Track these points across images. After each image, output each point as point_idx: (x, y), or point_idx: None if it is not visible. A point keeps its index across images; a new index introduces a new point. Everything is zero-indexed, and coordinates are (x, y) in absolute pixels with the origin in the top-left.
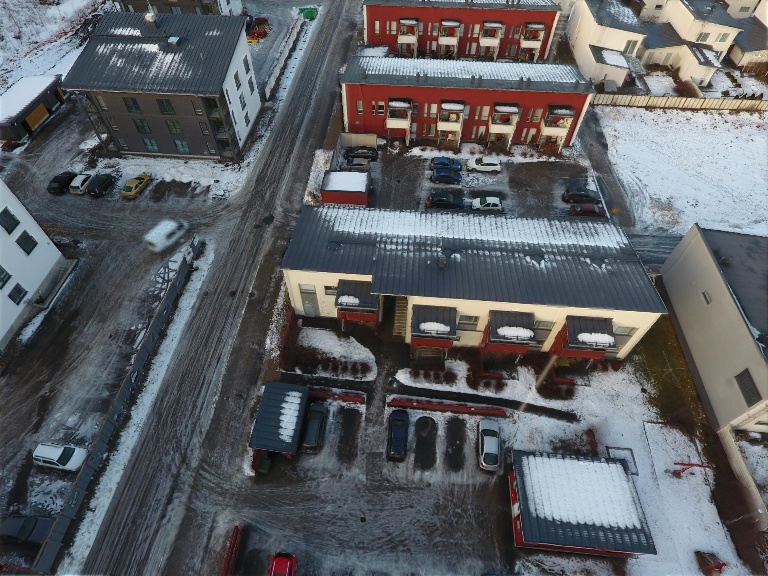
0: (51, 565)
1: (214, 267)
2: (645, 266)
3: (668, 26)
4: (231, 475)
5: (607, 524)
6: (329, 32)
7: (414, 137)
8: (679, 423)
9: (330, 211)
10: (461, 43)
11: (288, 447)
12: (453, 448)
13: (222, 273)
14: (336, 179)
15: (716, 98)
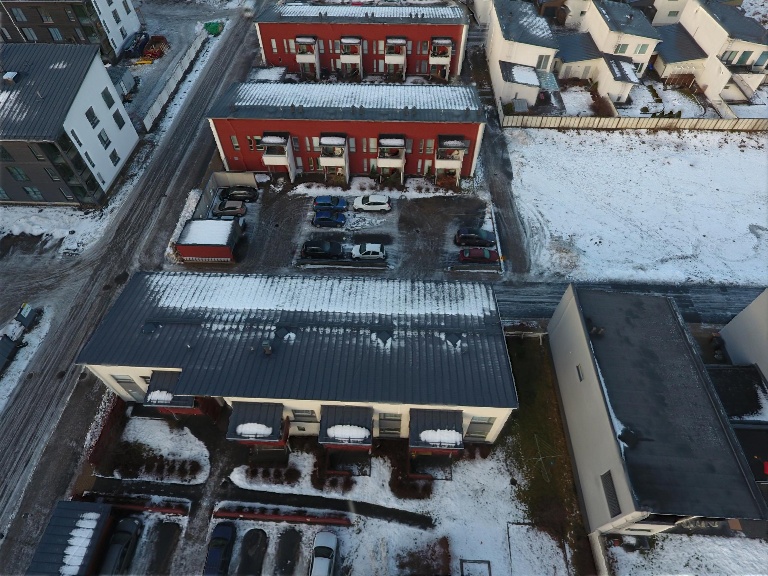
0: None
1: (46, 341)
2: (534, 321)
3: (587, 36)
4: None
5: None
6: (232, 50)
7: (300, 172)
8: (548, 523)
9: (163, 279)
10: (367, 60)
11: None
12: (282, 570)
13: (54, 349)
14: (196, 230)
15: (631, 117)
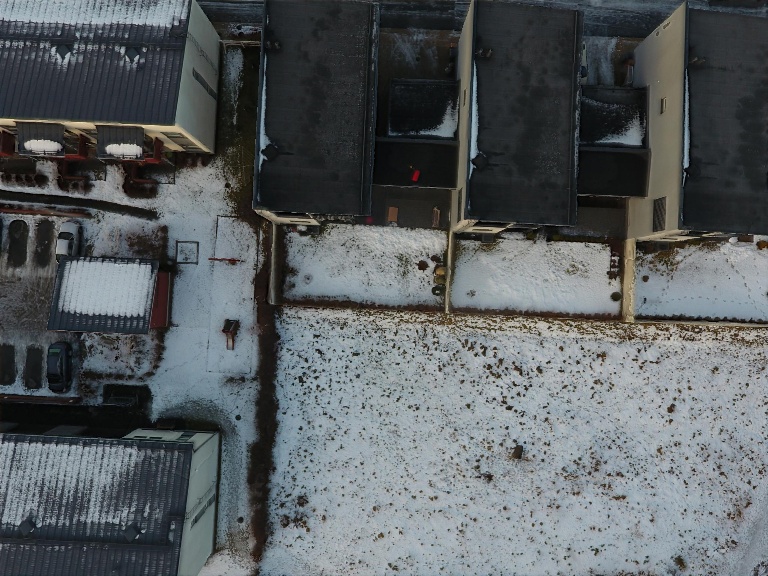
0: None
1: None
2: None
3: None
4: None
5: (116, 314)
6: None
7: None
8: (249, 216)
9: None
10: None
11: None
12: (41, 248)
13: None
14: None
15: None
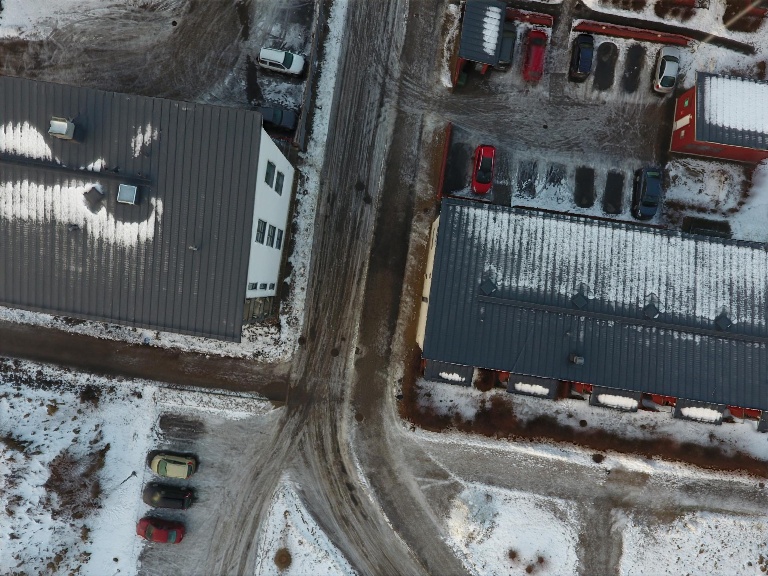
0: (303, 144)
1: None
2: None
3: None
4: (432, 86)
5: (767, 131)
6: None
7: None
8: None
9: None
10: None
11: (492, 59)
12: (630, 73)
13: None
14: None
15: None
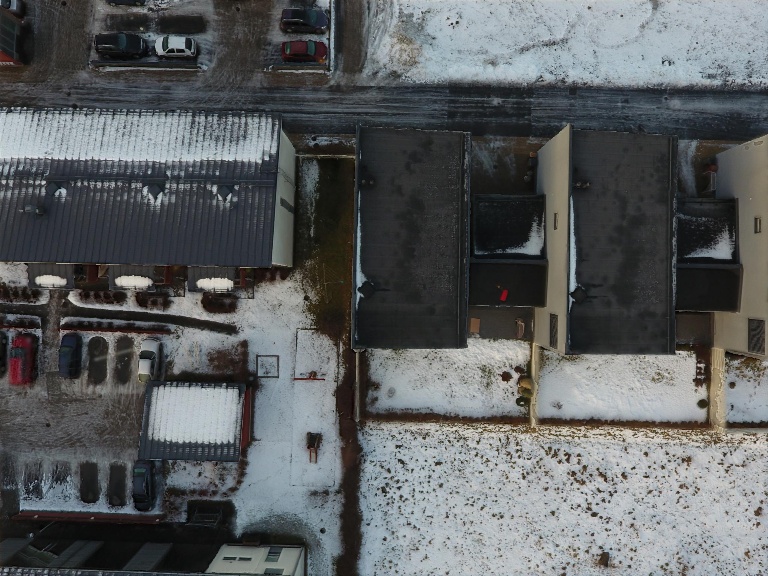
0: None
1: None
2: (353, 139)
3: None
4: None
5: (207, 442)
6: None
7: None
8: (329, 329)
9: None
10: None
11: None
12: (121, 364)
13: None
14: None
15: None
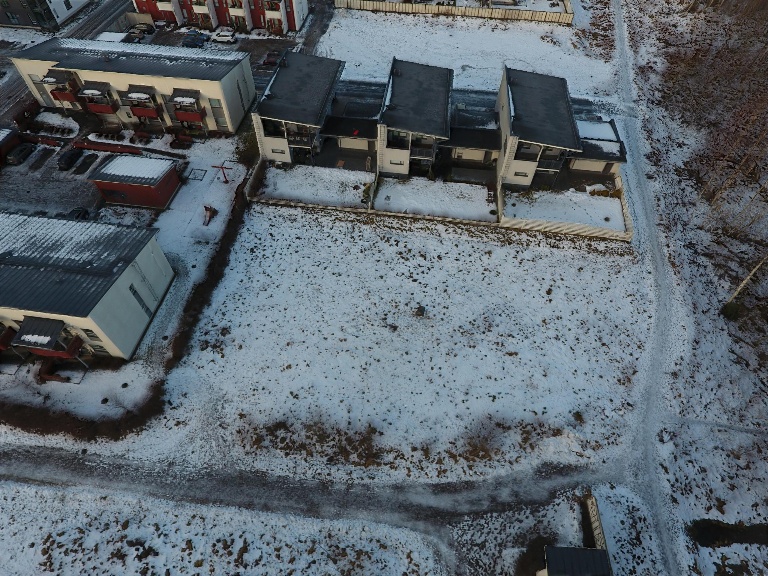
0: None
1: (5, 84)
2: None
3: None
4: None
5: (138, 176)
6: None
7: (185, 20)
8: (246, 162)
9: (67, 40)
10: None
11: None
12: None
13: (8, 87)
14: (104, 36)
15: (420, 4)
